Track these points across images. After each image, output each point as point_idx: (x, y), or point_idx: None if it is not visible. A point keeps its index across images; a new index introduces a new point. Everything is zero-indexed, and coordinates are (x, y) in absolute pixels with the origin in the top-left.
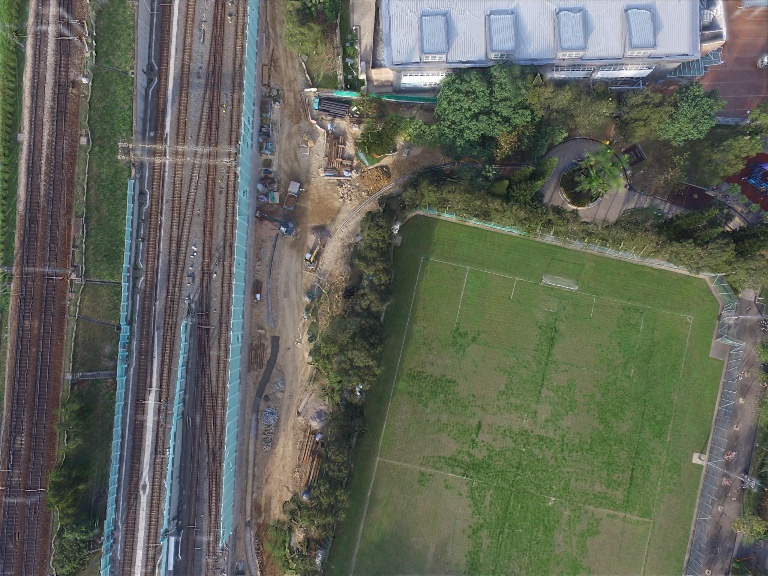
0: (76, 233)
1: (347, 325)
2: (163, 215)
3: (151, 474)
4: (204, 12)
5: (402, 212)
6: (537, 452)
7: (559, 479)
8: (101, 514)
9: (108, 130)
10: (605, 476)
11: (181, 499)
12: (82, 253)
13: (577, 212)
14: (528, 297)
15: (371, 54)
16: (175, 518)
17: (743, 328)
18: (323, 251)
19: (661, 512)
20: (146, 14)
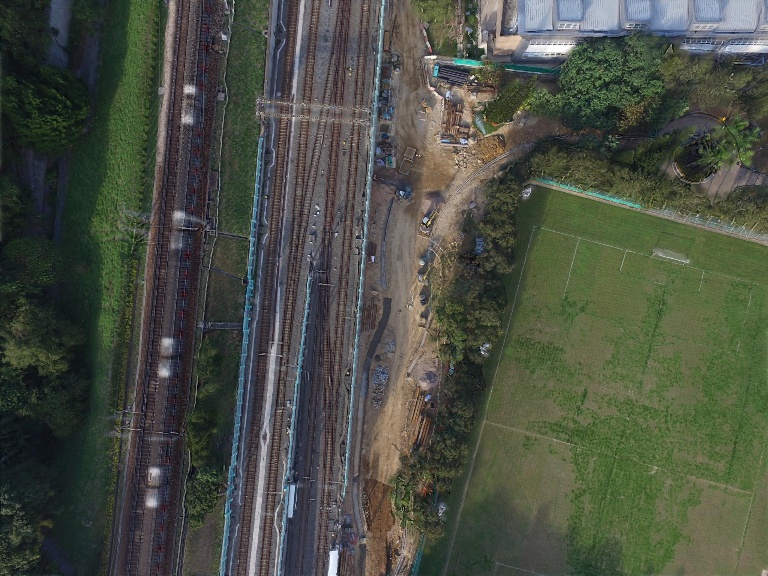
0: (211, 186)
1: (471, 286)
2: (288, 174)
3: (272, 425)
4: None
5: (528, 178)
6: (641, 422)
7: (662, 449)
8: (226, 460)
9: (242, 88)
10: (708, 448)
11: (297, 451)
12: (216, 206)
13: (690, 187)
14: (637, 269)
15: (492, 23)
16: (293, 468)
17: None
18: (437, 216)
19: (762, 485)
20: None
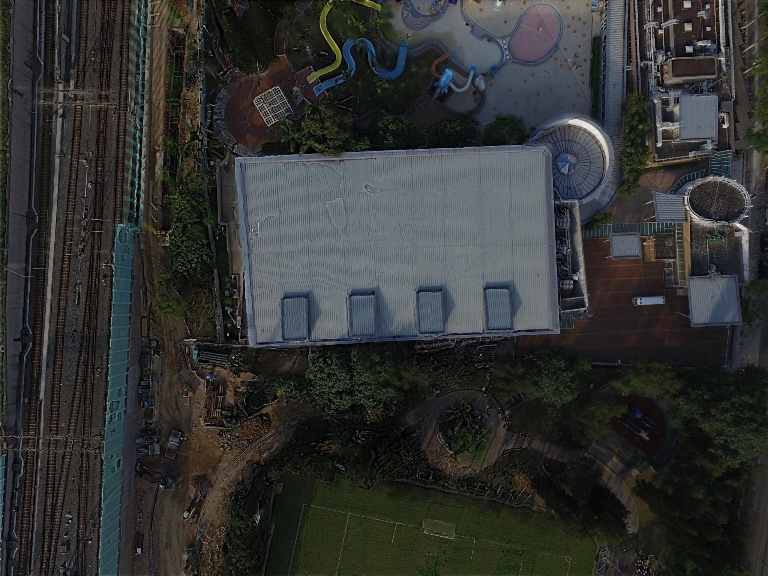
0: None
1: None
2: (38, 483)
3: None
4: (79, 274)
5: None
6: None
7: None
8: None
9: None
10: None
11: None
12: None
13: (455, 456)
14: (408, 541)
15: None
16: None
17: (620, 568)
18: (204, 501)
19: None
20: (18, 283)
